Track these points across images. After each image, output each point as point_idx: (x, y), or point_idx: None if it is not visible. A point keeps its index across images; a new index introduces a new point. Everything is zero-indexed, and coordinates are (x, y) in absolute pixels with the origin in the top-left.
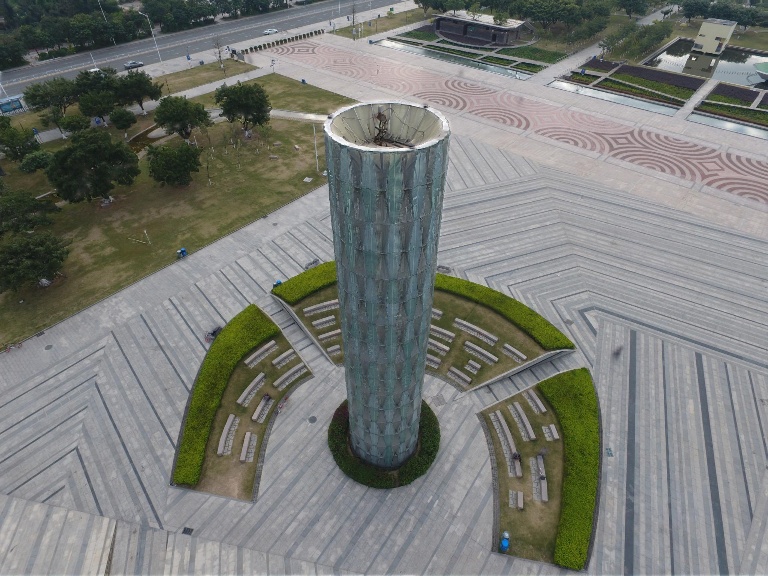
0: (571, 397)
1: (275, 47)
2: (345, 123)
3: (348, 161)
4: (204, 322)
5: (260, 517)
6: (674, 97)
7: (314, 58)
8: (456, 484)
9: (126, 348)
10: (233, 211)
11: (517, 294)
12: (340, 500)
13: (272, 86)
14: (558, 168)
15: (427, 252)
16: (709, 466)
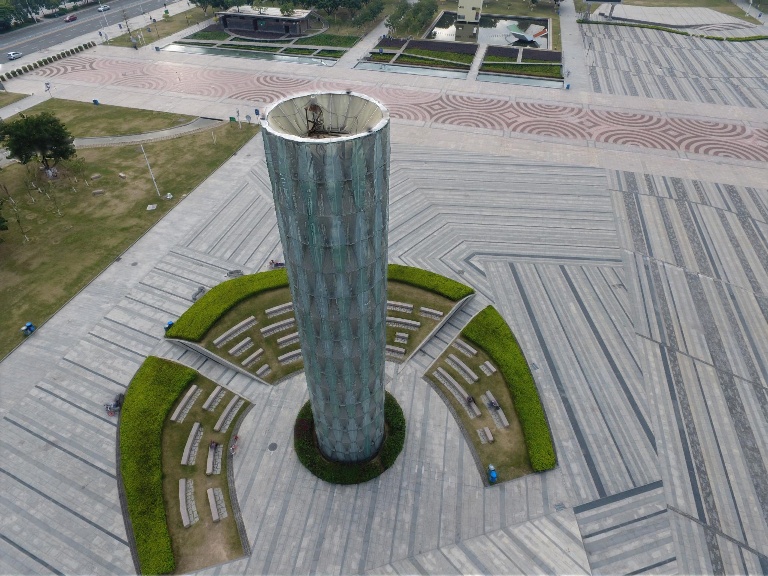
0: (491, 333)
1: (39, 68)
2: (277, 122)
3: (307, 158)
4: (97, 396)
5: (263, 566)
6: (460, 63)
7: (96, 74)
8: (432, 445)
9: (3, 463)
10: (74, 263)
11: (409, 261)
12: (336, 509)
13: (57, 113)
14: (395, 141)
15: (385, 233)
16: (602, 348)
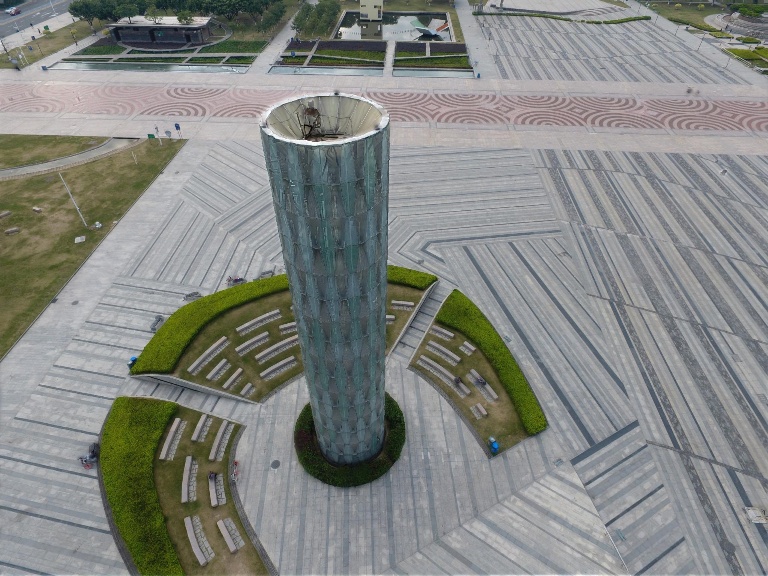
0: (463, 315)
1: None
2: (276, 129)
3: (321, 161)
4: (66, 451)
5: None
6: (374, 60)
7: None
8: (432, 430)
9: None
10: (1, 313)
11: None
12: (355, 511)
13: None
14: None
15: None
16: (562, 312)
